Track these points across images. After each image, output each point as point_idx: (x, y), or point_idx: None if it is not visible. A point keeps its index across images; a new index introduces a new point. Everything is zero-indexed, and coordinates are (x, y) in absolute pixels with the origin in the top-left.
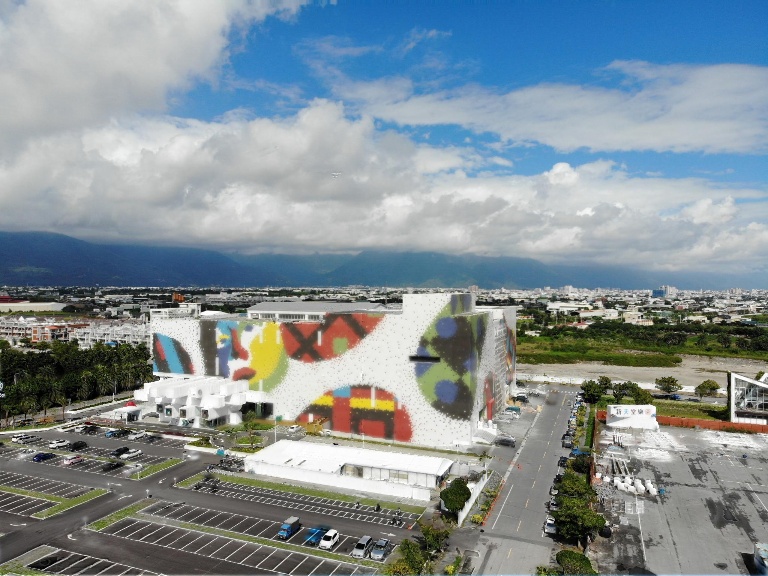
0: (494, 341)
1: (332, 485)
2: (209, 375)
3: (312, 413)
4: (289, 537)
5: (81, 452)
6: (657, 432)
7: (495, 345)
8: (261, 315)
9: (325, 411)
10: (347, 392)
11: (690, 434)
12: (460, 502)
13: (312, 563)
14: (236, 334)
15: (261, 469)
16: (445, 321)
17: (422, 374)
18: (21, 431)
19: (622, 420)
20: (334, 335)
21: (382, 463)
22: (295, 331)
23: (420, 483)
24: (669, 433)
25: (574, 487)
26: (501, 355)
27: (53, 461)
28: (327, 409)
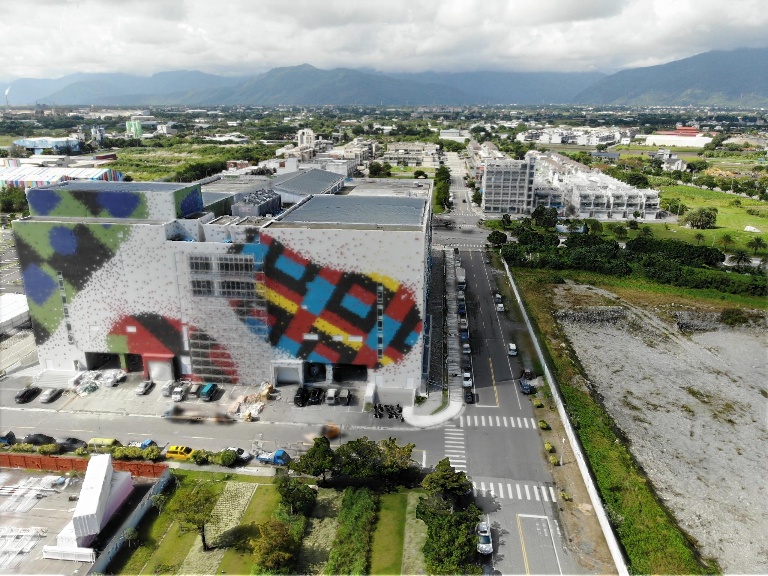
0: (184, 273)
1: None
2: None
3: None
4: None
5: None
6: None
7: (184, 280)
8: None
9: None
10: None
11: None
12: None
13: None
14: None
15: None
16: None
17: None
18: None
19: None
20: None
21: None
22: None
23: None
24: (26, 572)
25: None
26: (232, 303)
27: None
28: None
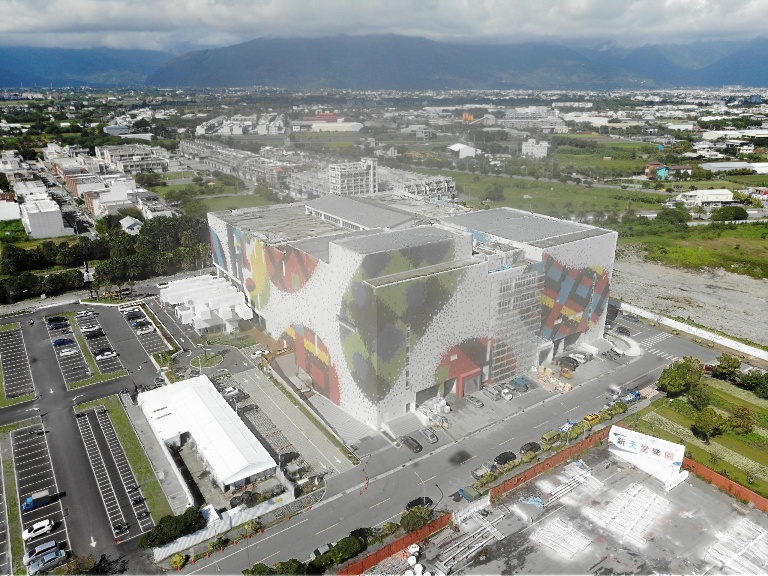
0: (495, 298)
1: None
2: (235, 276)
3: (285, 340)
4: (32, 509)
5: (91, 342)
6: (652, 493)
7: (495, 303)
8: (314, 212)
9: (292, 342)
10: (302, 331)
11: (711, 515)
12: (157, 540)
13: None
14: (243, 244)
15: (143, 409)
16: (357, 286)
17: (344, 338)
18: (100, 304)
19: (627, 452)
20: (291, 269)
21: (207, 444)
22: (271, 255)
23: (217, 481)
24: (678, 500)
25: None
26: (522, 311)
27: (63, 348)
28: (292, 341)
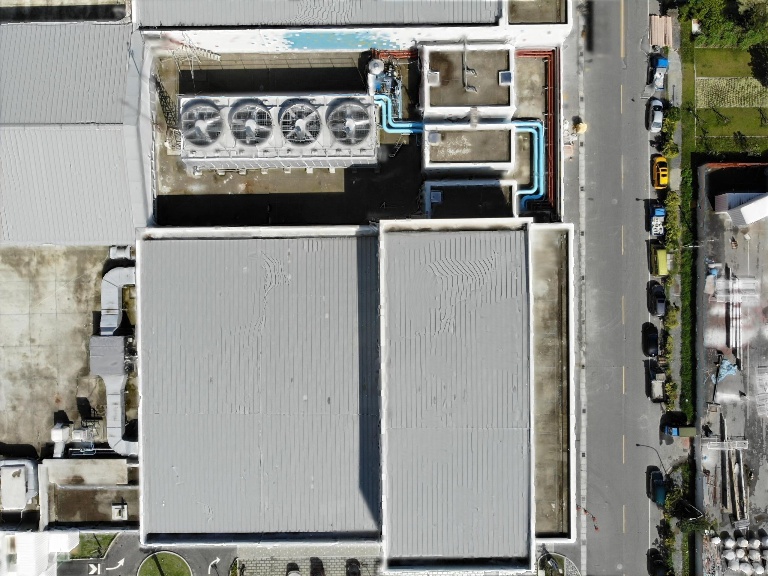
0: None
1: None
2: None
3: None
4: None
5: None
6: None
7: None
8: None
9: None
10: None
11: None
12: None
13: None
14: None
15: None
16: None
17: None
18: None
19: None
20: None
21: None
22: None
23: None
24: None
25: None
26: None
27: None
28: None
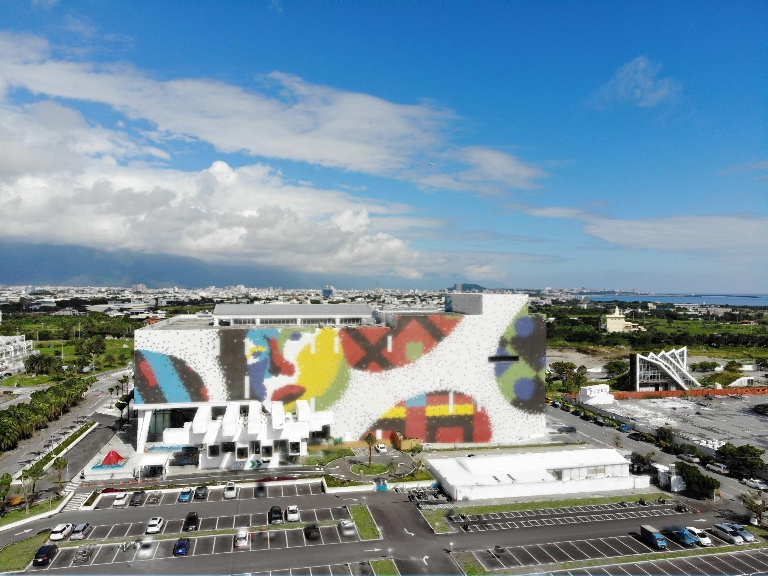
0: None
1: (557, 493)
2: (234, 400)
3: (381, 429)
4: None
5: (210, 527)
6: (623, 405)
7: None
8: (233, 321)
9: (396, 424)
10: (422, 400)
11: (637, 404)
12: None
13: (732, 560)
14: (277, 345)
15: (476, 493)
16: (524, 320)
17: (502, 374)
18: (17, 523)
19: (591, 399)
20: (408, 340)
21: (576, 462)
22: (359, 337)
23: (616, 474)
24: None
25: (759, 450)
26: None
27: (205, 548)
28: (399, 422)
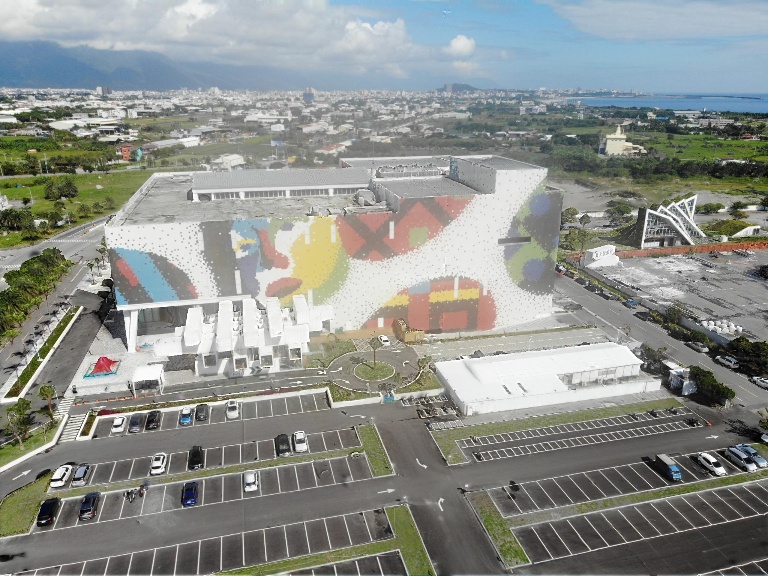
0: None
1: (568, 402)
2: (226, 296)
3: (382, 317)
4: None
5: (216, 463)
6: (628, 268)
7: None
8: (214, 195)
9: (399, 312)
10: (426, 287)
11: (642, 265)
12: None
13: (745, 494)
14: (267, 236)
15: (487, 408)
16: (540, 198)
17: (511, 256)
18: (13, 463)
19: (596, 262)
20: (411, 224)
21: (588, 365)
22: (358, 224)
23: (627, 374)
24: None
25: None
26: None
27: (214, 494)
28: (401, 309)
